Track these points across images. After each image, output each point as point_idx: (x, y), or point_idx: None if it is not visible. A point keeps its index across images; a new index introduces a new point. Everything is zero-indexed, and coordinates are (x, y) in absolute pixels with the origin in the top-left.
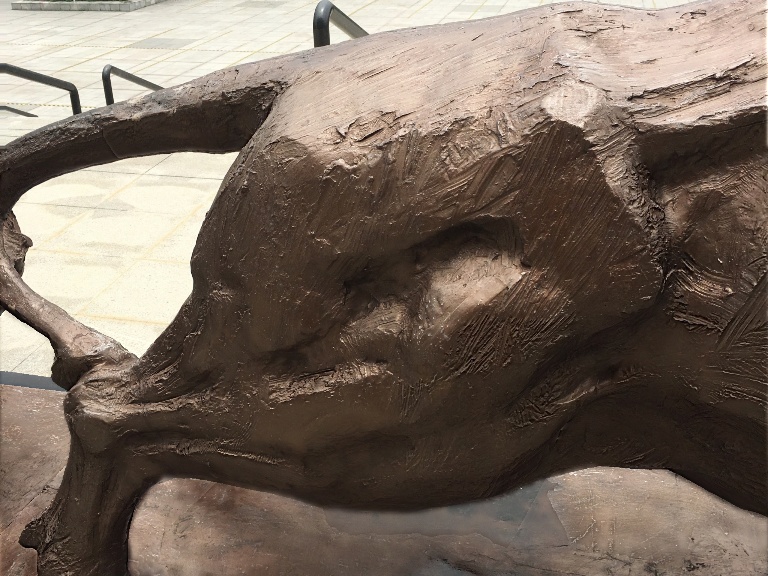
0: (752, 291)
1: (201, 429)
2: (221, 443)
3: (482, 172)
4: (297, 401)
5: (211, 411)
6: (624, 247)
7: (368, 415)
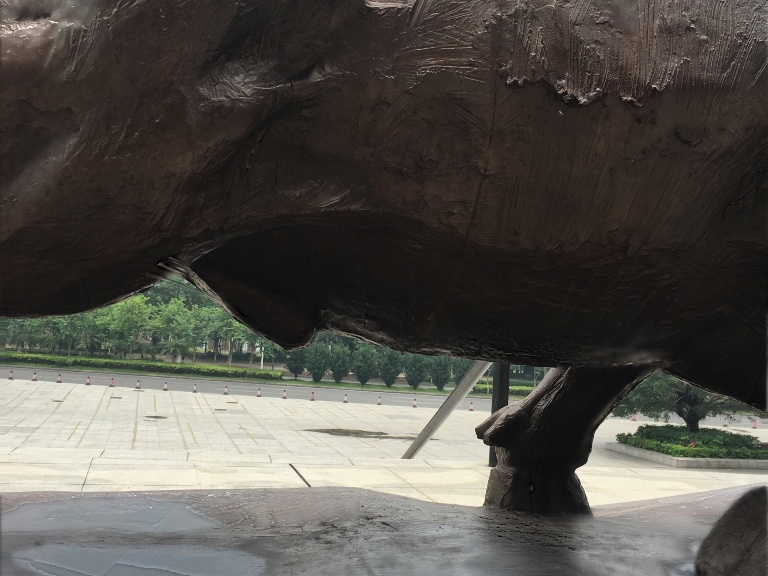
0: None
1: None
2: None
3: None
4: None
5: None
6: None
7: (19, 74)
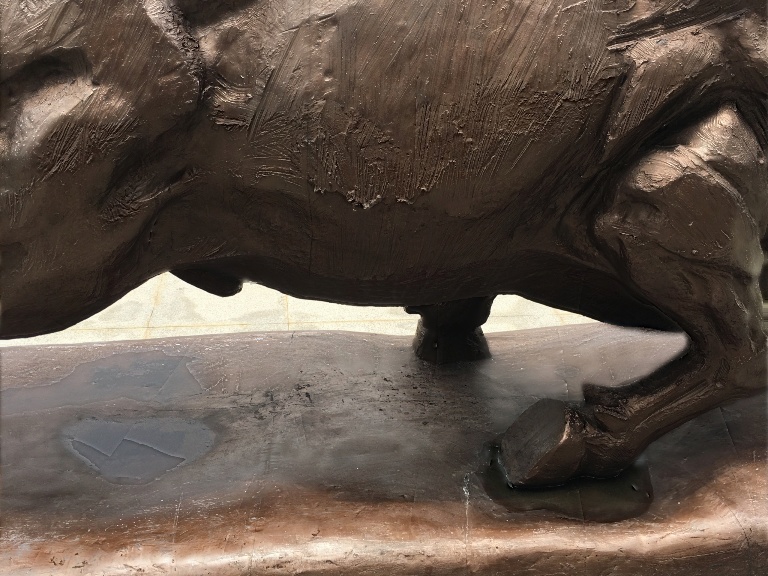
0: (263, 92)
1: None
2: None
3: (54, 15)
4: None
5: None
6: (167, 63)
7: None
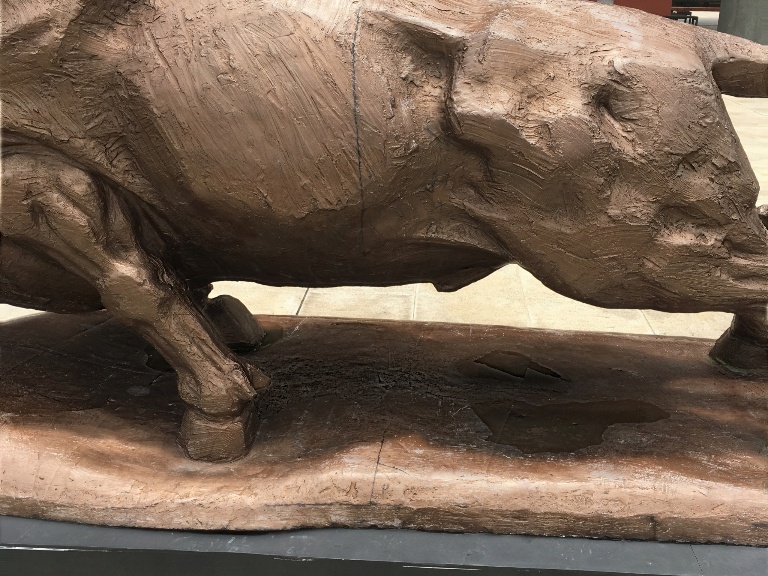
0: None
1: None
2: None
3: None
4: None
5: None
6: None
7: None
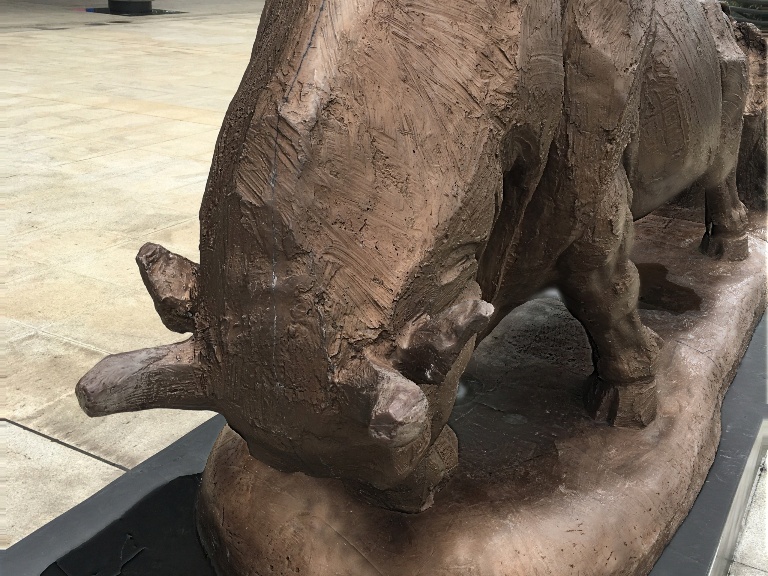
0: None
1: None
2: None
3: None
4: None
5: None
6: None
7: None
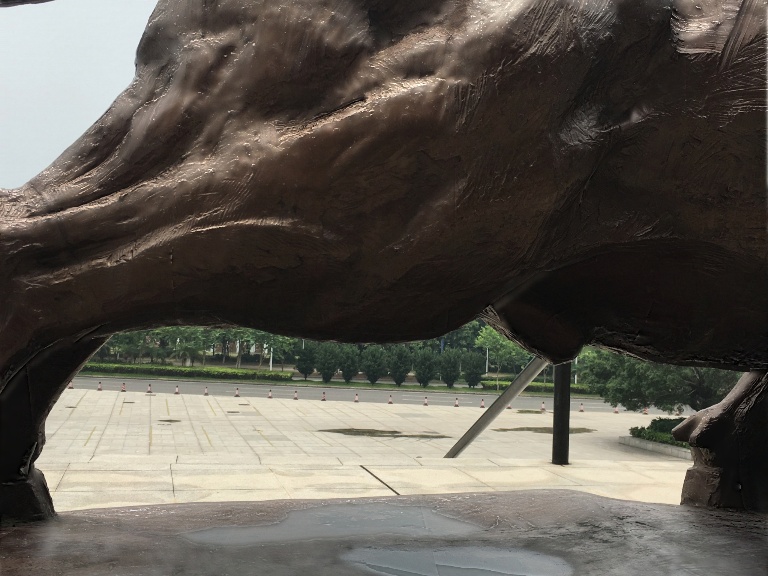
0: (737, 15)
1: (162, 211)
2: (198, 218)
3: None
4: (322, 132)
5: (184, 179)
6: None
7: (419, 128)
